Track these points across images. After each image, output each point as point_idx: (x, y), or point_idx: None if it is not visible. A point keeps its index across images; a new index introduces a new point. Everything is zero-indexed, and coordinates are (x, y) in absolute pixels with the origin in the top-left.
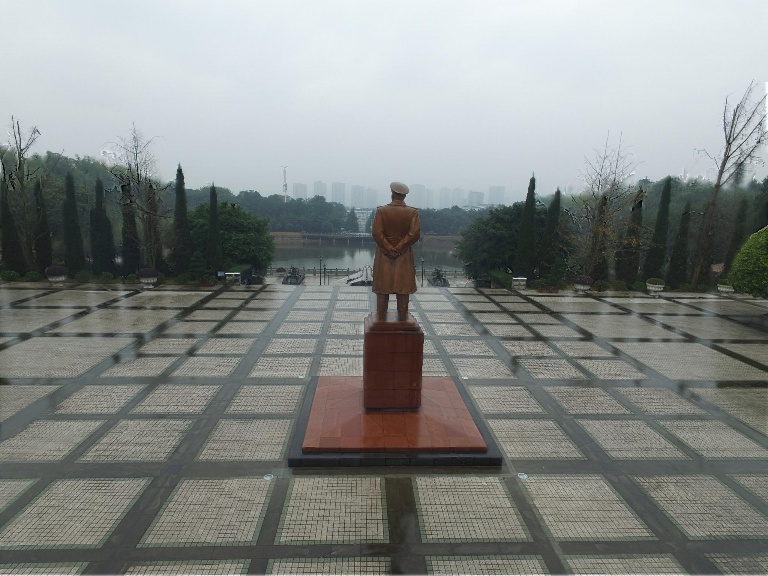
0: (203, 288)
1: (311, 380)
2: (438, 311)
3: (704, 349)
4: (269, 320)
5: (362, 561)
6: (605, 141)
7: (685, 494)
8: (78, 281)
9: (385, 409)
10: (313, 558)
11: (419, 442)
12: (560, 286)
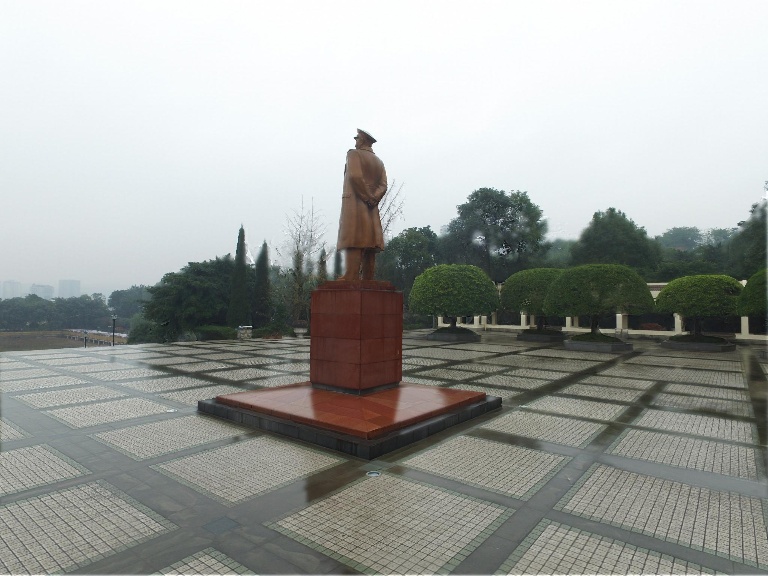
0: None
1: (209, 403)
2: (205, 354)
3: (439, 349)
4: None
5: (593, 472)
6: (301, 203)
7: (588, 391)
8: None
9: (375, 388)
10: (571, 489)
11: (445, 402)
12: (279, 333)
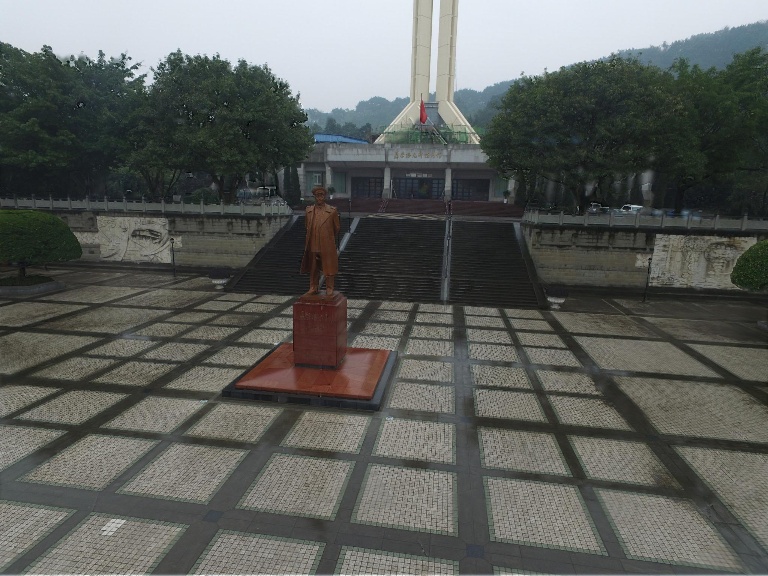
0: None
1: (380, 398)
2: None
3: None
4: None
5: (369, 333)
6: None
7: None
8: None
9: None
10: None
11: None
12: None
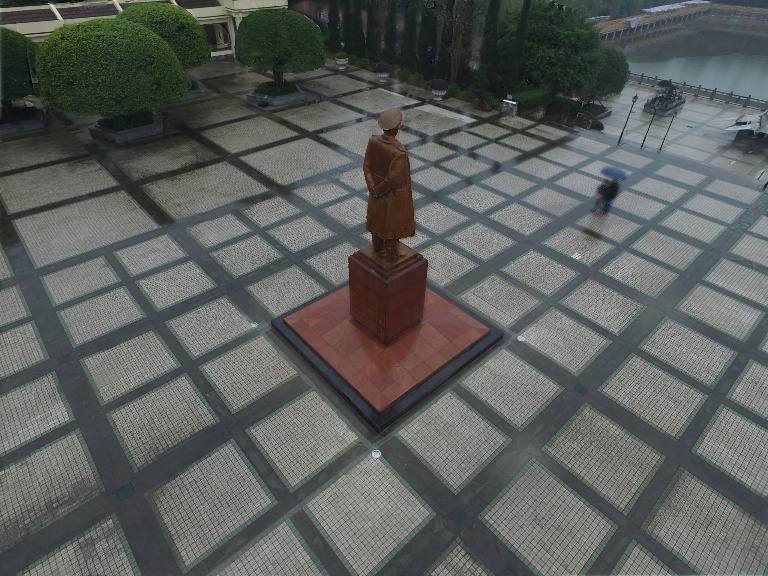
0: (476, 112)
1: None
2: (674, 235)
3: None
4: (466, 176)
5: (209, 411)
6: None
7: None
8: (400, 78)
9: (364, 326)
10: (198, 389)
11: (345, 369)
12: None
